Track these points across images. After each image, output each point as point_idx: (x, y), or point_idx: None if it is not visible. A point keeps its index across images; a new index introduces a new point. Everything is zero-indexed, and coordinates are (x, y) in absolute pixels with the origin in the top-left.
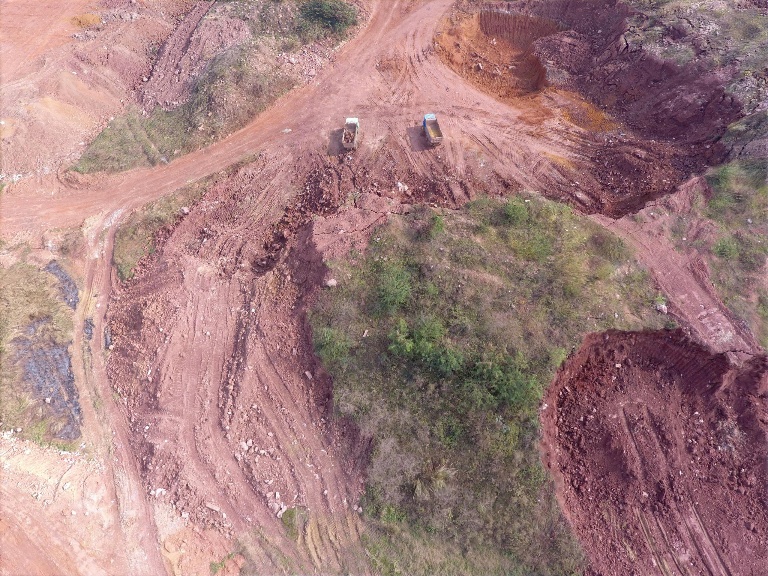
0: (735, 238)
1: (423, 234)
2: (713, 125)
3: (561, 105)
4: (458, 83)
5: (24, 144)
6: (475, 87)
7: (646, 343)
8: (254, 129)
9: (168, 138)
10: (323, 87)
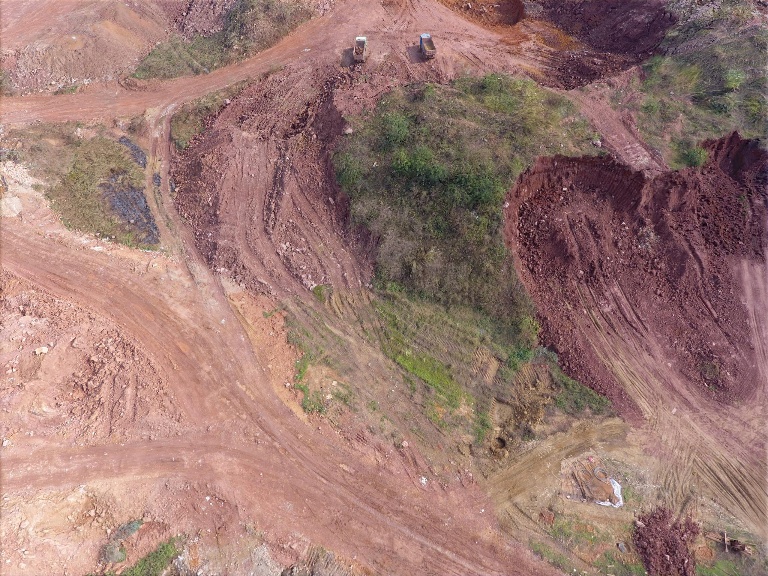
0: (659, 104)
1: (418, 96)
2: (656, 37)
3: (536, 31)
4: (450, 15)
5: (92, 55)
6: (464, 18)
7: (586, 172)
8: (279, 49)
9: (208, 56)
10: (336, 18)
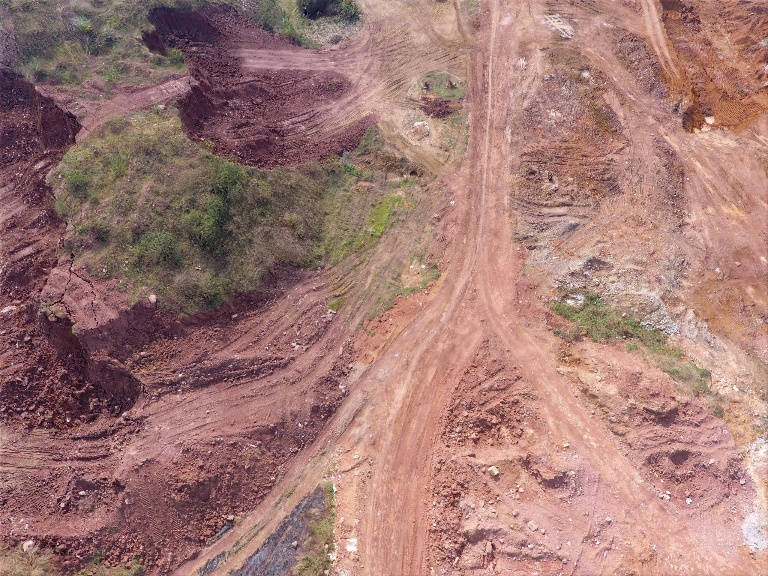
0: (100, 74)
1: (101, 235)
2: None
3: None
4: None
5: None
6: None
7: (186, 123)
8: None
9: None
10: None
